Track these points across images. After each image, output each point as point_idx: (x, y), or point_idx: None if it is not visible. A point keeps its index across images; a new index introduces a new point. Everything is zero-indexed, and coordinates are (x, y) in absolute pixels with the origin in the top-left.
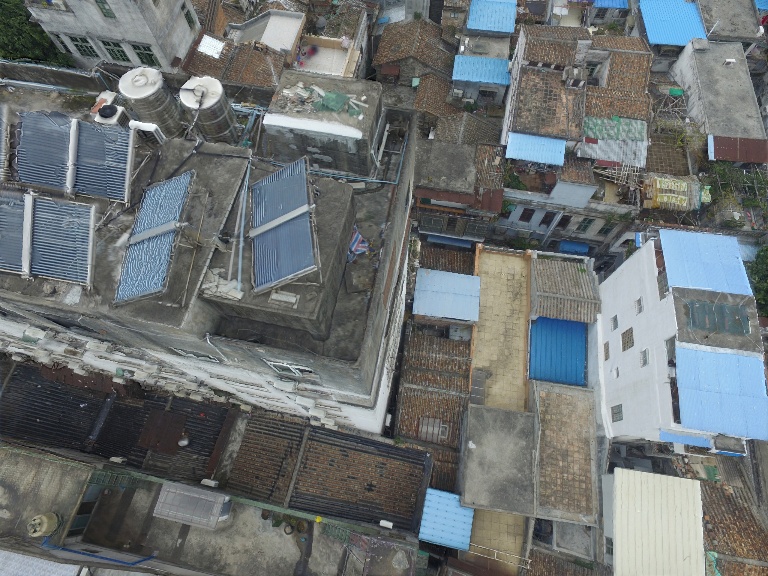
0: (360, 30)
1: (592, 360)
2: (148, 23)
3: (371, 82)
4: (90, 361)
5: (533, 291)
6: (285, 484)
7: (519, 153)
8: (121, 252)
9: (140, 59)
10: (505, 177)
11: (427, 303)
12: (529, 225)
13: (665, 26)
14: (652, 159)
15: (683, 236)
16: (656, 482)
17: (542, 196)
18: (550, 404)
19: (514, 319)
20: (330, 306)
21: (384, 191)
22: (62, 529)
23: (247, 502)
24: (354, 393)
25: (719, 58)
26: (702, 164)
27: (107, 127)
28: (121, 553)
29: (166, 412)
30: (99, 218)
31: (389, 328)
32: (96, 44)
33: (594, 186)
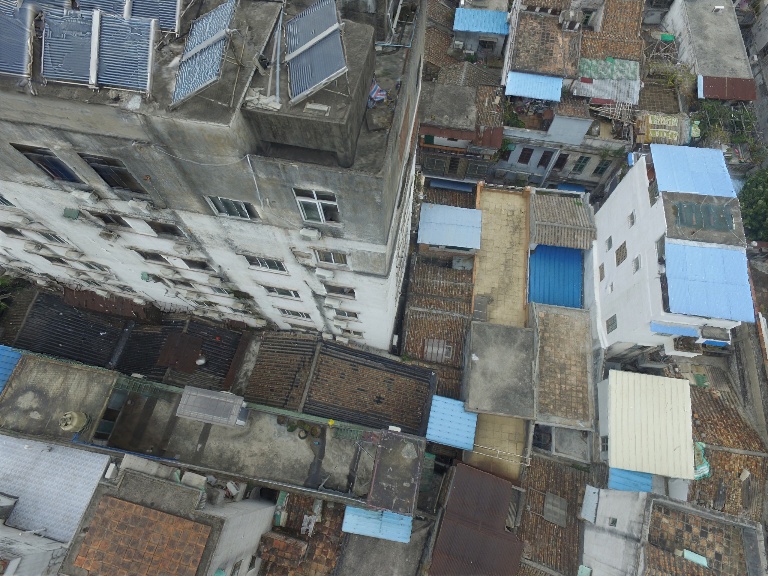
0: None
1: (588, 284)
2: None
3: None
4: (116, 267)
5: (532, 222)
6: (299, 393)
7: (518, 90)
8: (174, 71)
9: None
10: (505, 115)
11: (431, 233)
12: (528, 167)
13: None
14: (645, 102)
15: (672, 149)
16: (648, 382)
17: (540, 133)
18: (548, 323)
19: (514, 251)
20: (355, 131)
21: (399, 53)
22: (91, 427)
23: (263, 408)
24: (372, 244)
25: (708, 6)
26: (692, 104)
27: None
28: (145, 455)
29: (184, 334)
30: None
31: (401, 202)
32: None
33: (589, 119)
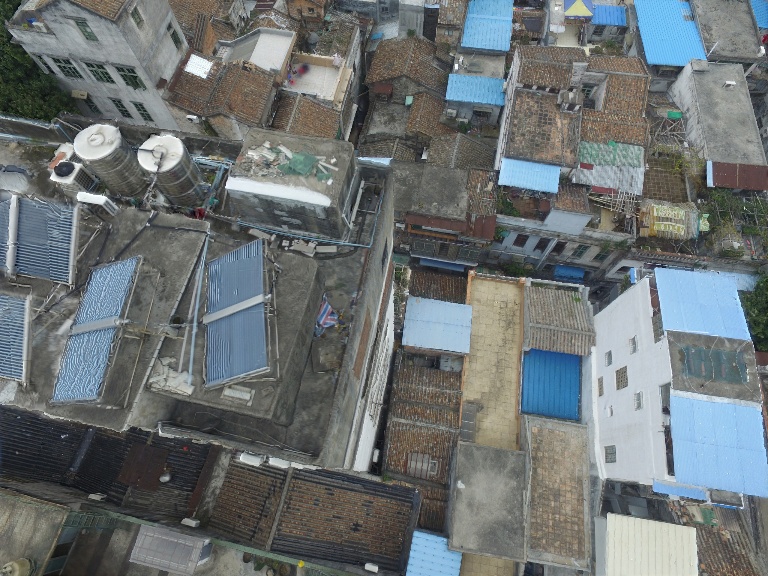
0: (352, 47)
1: (586, 394)
2: (131, 46)
3: (342, 142)
4: None
5: (526, 321)
6: (268, 525)
7: (512, 180)
8: (63, 341)
9: (125, 81)
10: (498, 204)
11: (417, 333)
12: (523, 250)
13: (664, 46)
14: (649, 184)
15: (679, 275)
16: (650, 529)
17: (536, 223)
18: (542, 440)
19: (507, 349)
20: (292, 392)
21: (357, 255)
22: (35, 575)
23: (228, 545)
24: None
25: (719, 80)
26: (701, 190)
27: (64, 185)
28: None
29: (147, 446)
30: (41, 302)
31: (367, 387)
32: (79, 66)
33: (589, 215)
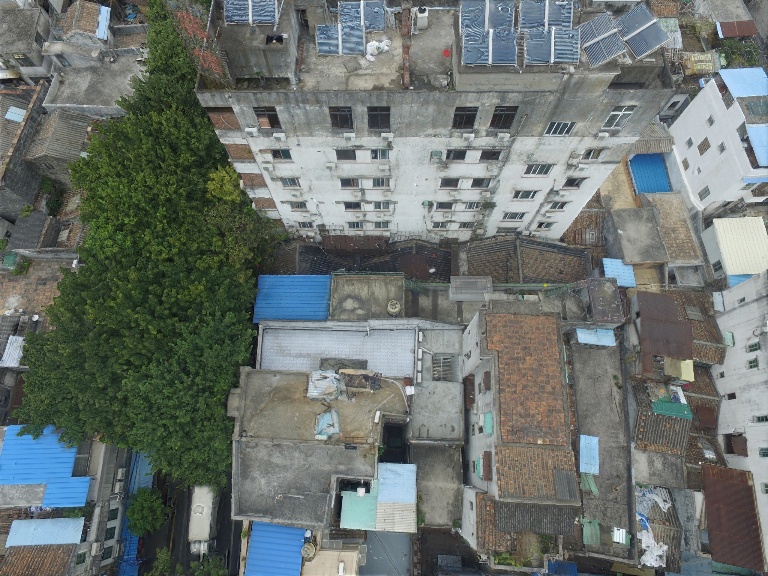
0: None
1: (674, 175)
2: None
3: None
4: (404, 201)
5: None
6: (515, 273)
7: None
8: None
9: None
10: None
11: None
12: None
13: None
14: None
15: (732, 71)
16: (738, 222)
17: None
18: (656, 204)
19: None
20: None
21: None
22: (403, 310)
23: (498, 285)
24: (632, 137)
25: None
26: (714, 43)
27: None
28: None
29: (414, 254)
30: None
31: None
32: None
33: None
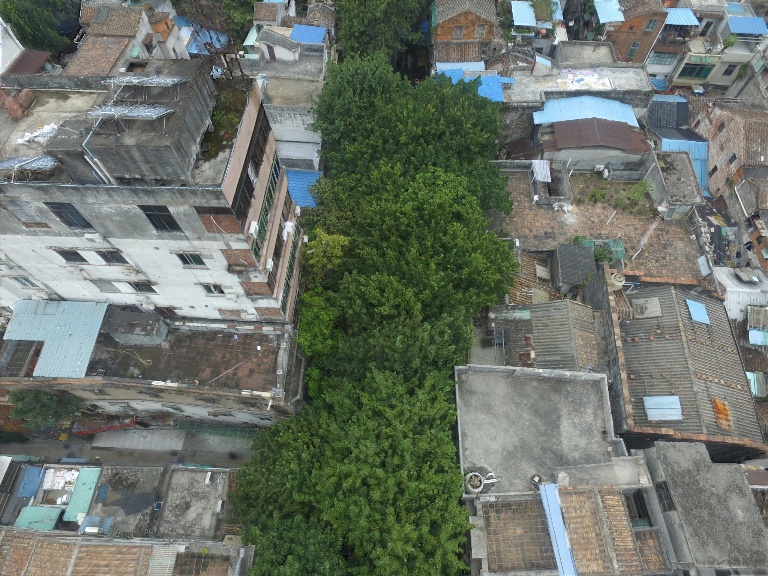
0: None
1: None
2: None
3: None
4: None
5: None
6: None
7: None
8: None
9: None
10: None
11: None
12: None
13: None
14: None
15: None
16: None
17: None
18: None
19: None
20: None
21: None
22: None
23: None
24: None
25: None
26: None
27: None
28: None
29: None
30: None
31: None
32: None
33: None
